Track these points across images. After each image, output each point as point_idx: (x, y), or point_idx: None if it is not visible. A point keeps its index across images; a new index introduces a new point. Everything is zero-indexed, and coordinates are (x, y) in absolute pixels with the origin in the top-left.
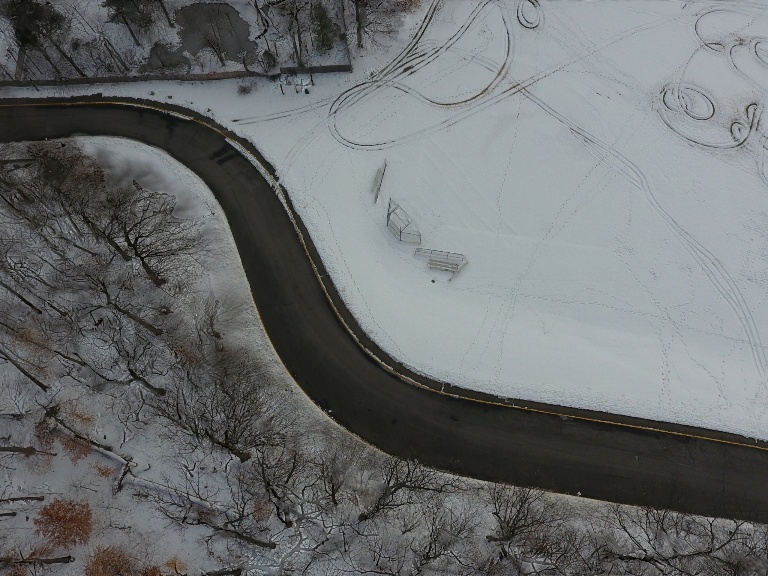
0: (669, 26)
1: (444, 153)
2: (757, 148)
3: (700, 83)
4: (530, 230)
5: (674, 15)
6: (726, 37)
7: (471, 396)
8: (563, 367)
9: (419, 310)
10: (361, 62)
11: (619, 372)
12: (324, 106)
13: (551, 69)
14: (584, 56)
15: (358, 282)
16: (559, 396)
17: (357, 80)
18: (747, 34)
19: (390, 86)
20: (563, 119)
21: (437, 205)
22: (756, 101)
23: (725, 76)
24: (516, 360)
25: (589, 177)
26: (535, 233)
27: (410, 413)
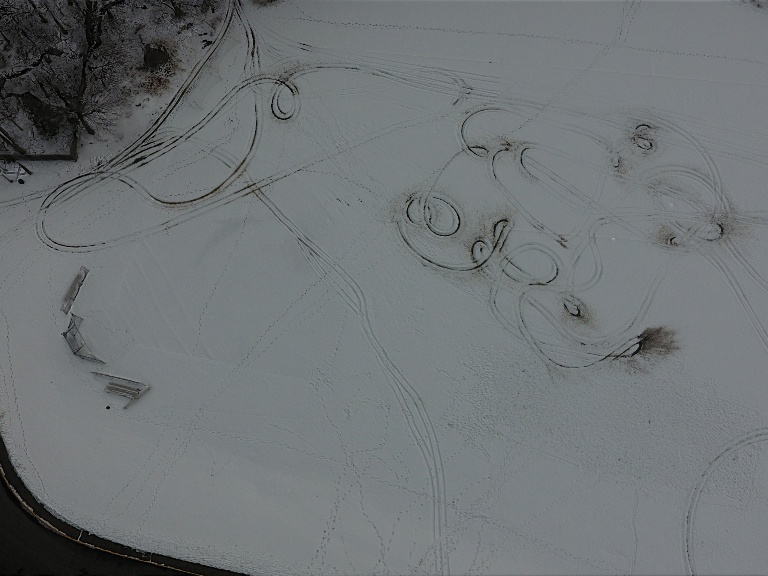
0: (433, 124)
1: (155, 260)
2: (495, 272)
3: (451, 193)
4: (227, 354)
5: (442, 112)
6: (492, 140)
7: (107, 547)
8: (217, 518)
9: (82, 442)
10: (89, 150)
11: (277, 527)
12: (37, 199)
13: (293, 168)
14: (333, 155)
15: (21, 407)
16: (201, 553)
17: (81, 170)
18: (516, 138)
19: (115, 179)
20: (292, 227)
21: (133, 320)
22: (507, 217)
23: (480, 186)
24: (168, 508)
25: (305, 296)
26: (231, 358)
27: (40, 562)
